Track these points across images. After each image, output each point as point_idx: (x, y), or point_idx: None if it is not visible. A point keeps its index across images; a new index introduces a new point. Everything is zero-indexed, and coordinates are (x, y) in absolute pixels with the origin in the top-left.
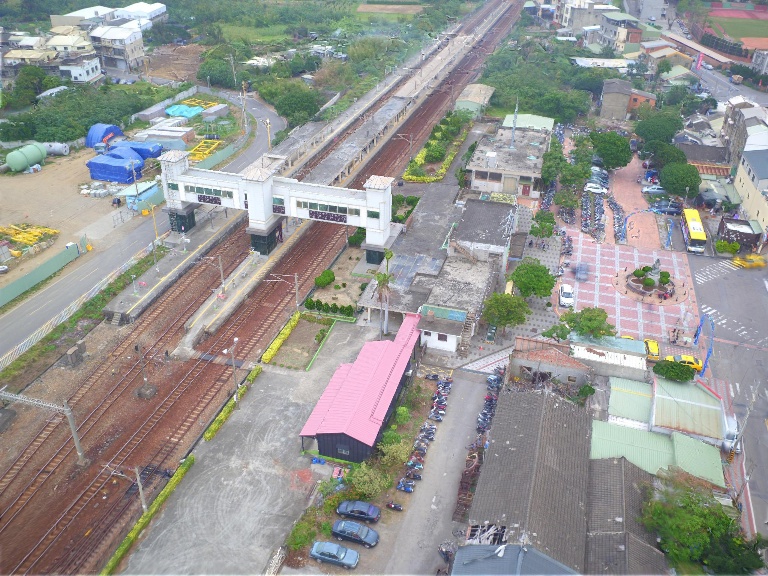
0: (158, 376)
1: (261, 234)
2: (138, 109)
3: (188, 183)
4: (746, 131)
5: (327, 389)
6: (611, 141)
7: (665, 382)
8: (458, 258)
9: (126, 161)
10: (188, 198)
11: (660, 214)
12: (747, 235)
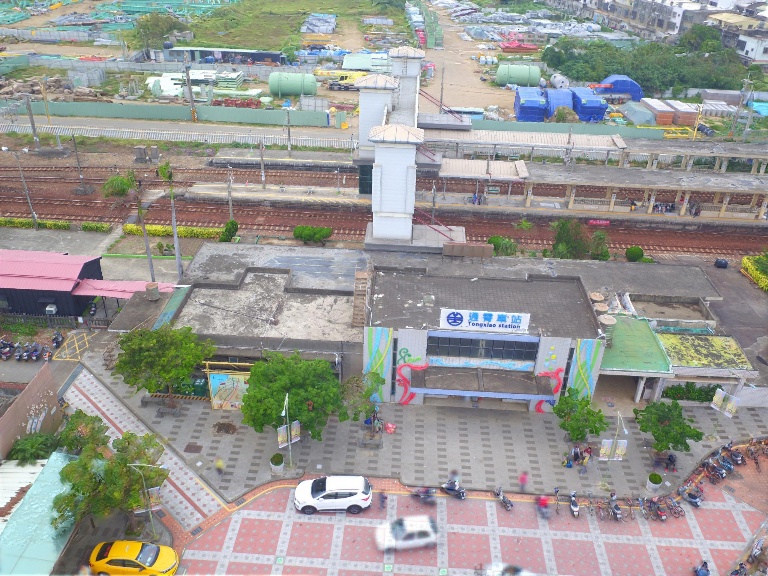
0: None
1: None
2: (711, 85)
3: None
4: None
5: (13, 250)
6: None
7: None
8: None
9: (535, 97)
10: None
11: None
12: None
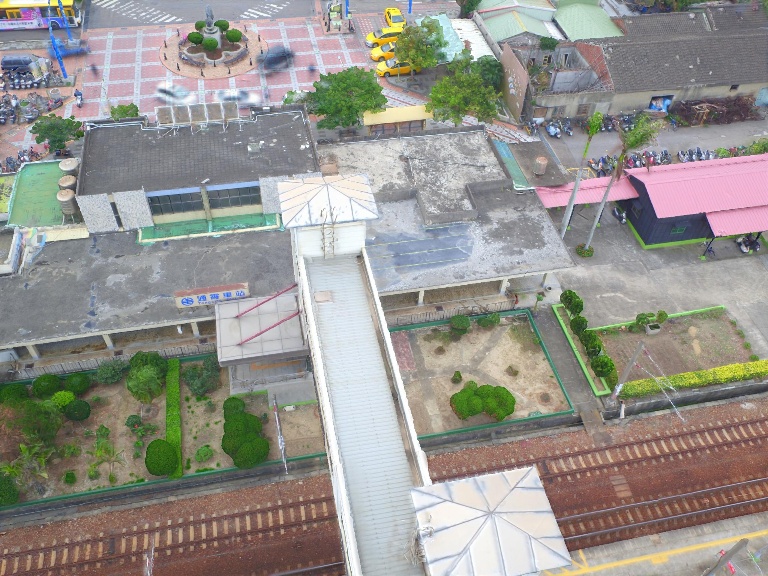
0: None
1: None
2: None
3: None
4: None
5: None
6: None
7: (484, 5)
8: None
9: None
10: None
11: None
12: None
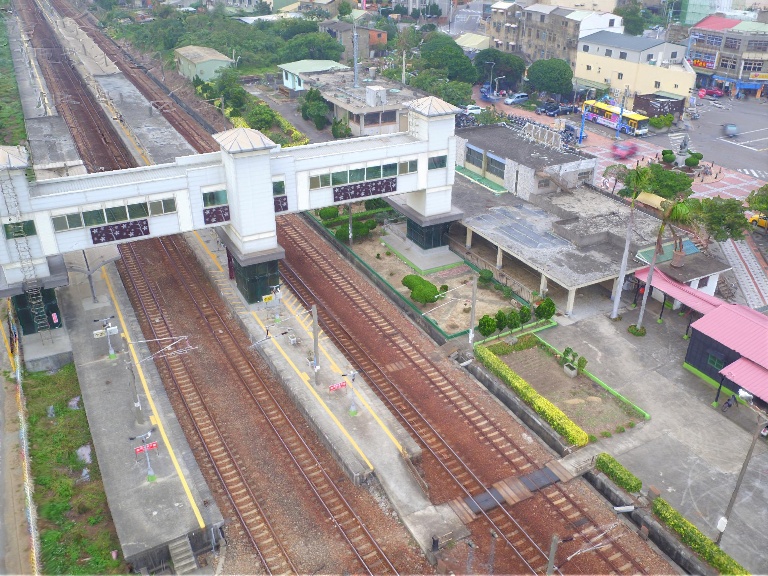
0: None
1: (274, 257)
2: None
3: (61, 209)
4: (570, 19)
5: None
6: (459, 55)
7: None
8: (544, 195)
9: None
10: (64, 245)
11: (556, 116)
12: (676, 103)
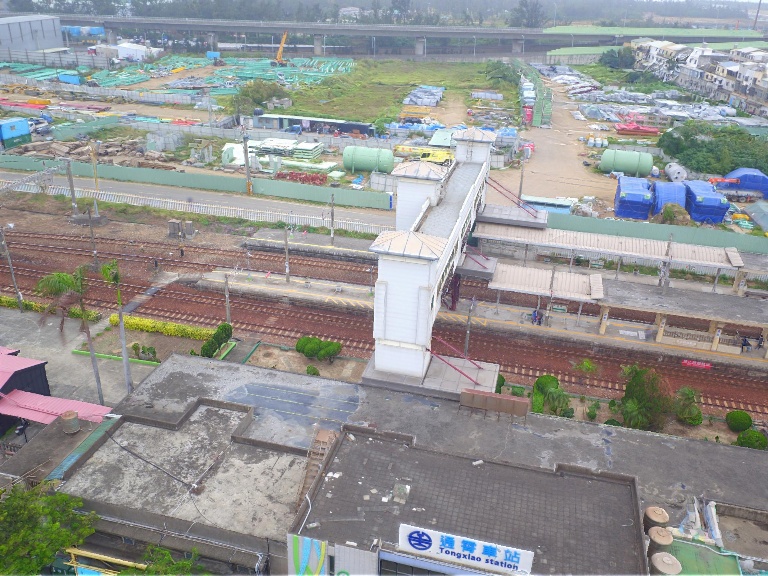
0: (128, 270)
1: None
2: None
3: None
4: None
5: None
6: None
7: None
8: None
9: (639, 190)
10: None
11: None
12: None
